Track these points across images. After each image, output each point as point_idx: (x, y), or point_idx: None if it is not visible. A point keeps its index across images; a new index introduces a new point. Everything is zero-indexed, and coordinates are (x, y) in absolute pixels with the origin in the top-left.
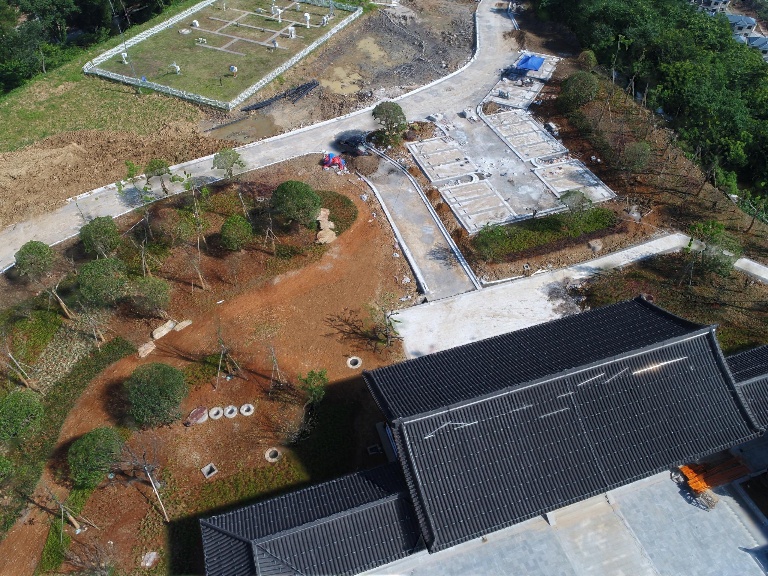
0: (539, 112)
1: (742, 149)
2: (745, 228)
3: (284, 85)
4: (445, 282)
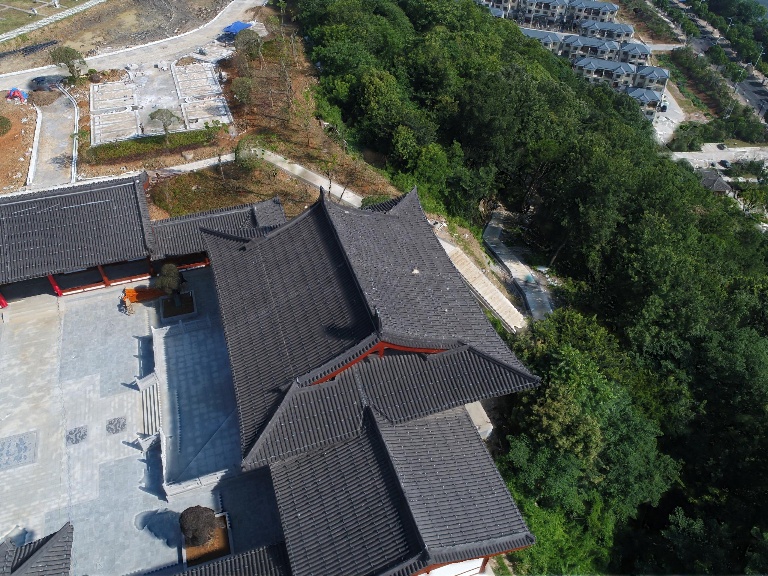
0: (222, 65)
1: (347, 89)
2: (310, 143)
3: (26, 43)
4: (49, 178)
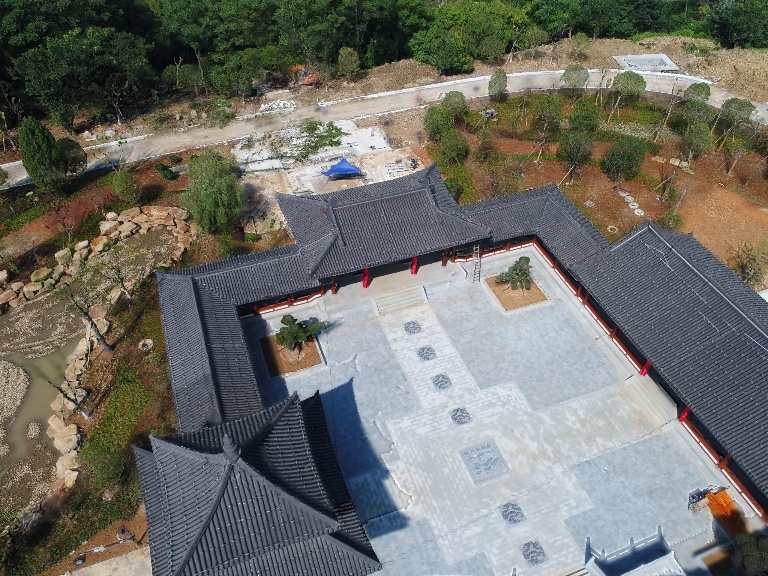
0: None
1: None
2: None
3: None
4: None
